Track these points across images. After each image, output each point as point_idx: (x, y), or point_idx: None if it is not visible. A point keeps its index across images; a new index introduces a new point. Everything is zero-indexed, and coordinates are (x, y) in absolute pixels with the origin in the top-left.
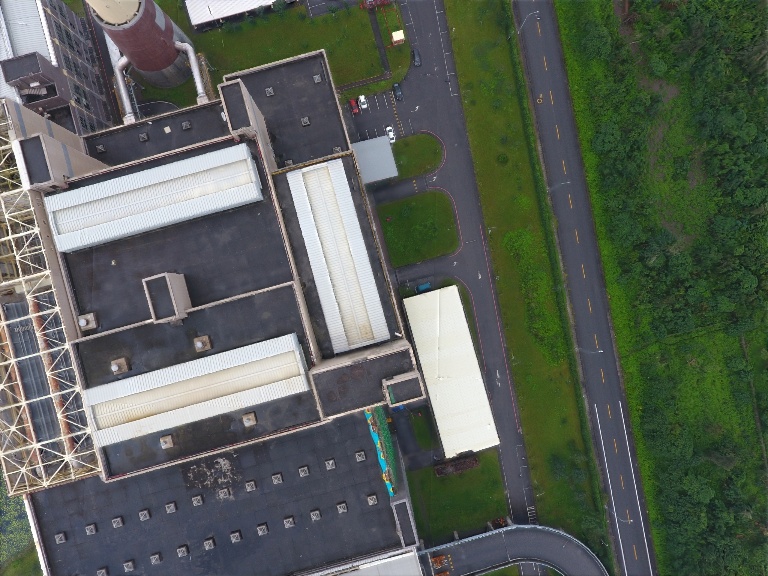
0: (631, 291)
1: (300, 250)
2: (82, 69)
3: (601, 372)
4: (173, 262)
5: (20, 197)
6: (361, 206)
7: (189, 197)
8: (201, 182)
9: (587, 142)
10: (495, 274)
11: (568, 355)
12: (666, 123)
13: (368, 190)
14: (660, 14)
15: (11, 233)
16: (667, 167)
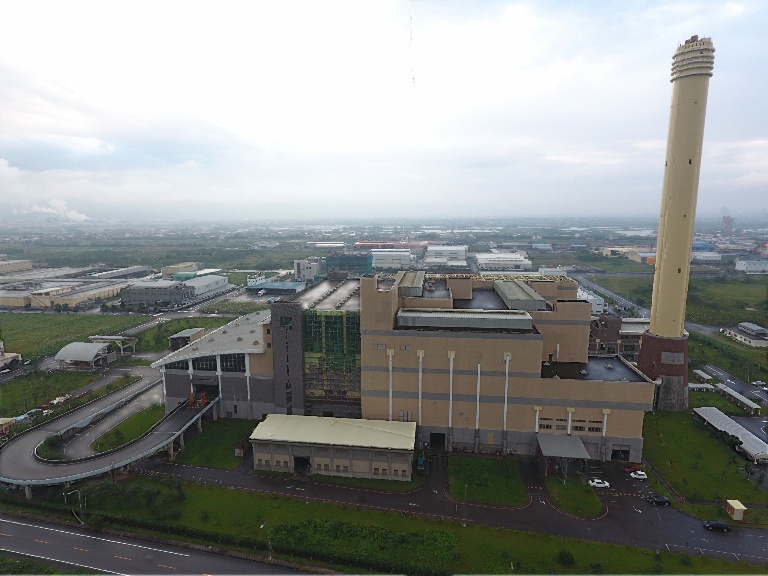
0: None
1: None
2: None
3: None
4: (480, 299)
5: None
6: None
7: None
8: None
9: None
10: None
11: None
12: None
13: (534, 459)
14: None
15: None
16: None
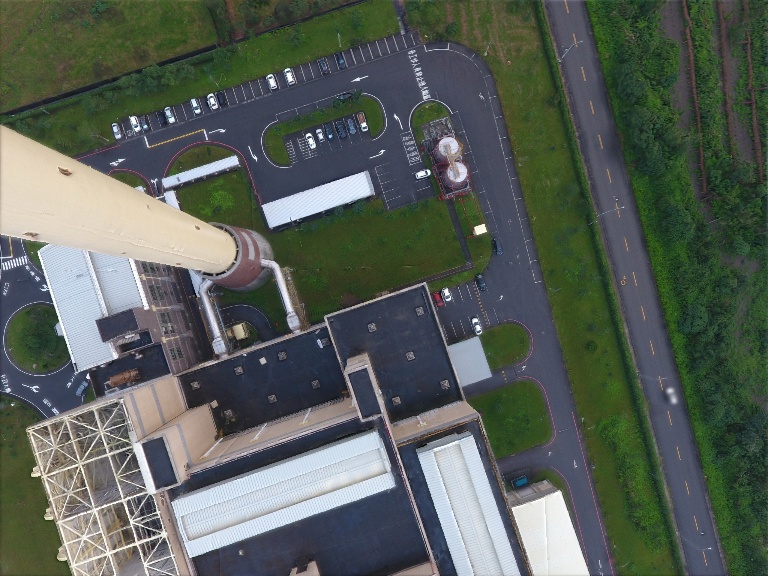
0: (728, 471)
1: (430, 521)
2: (163, 287)
3: (703, 555)
4: (303, 548)
5: (144, 500)
6: (490, 471)
7: (321, 490)
8: (333, 473)
9: (674, 323)
10: (591, 463)
11: (670, 541)
12: (749, 297)
13: None
14: (737, 191)
15: (137, 539)
16: (753, 340)
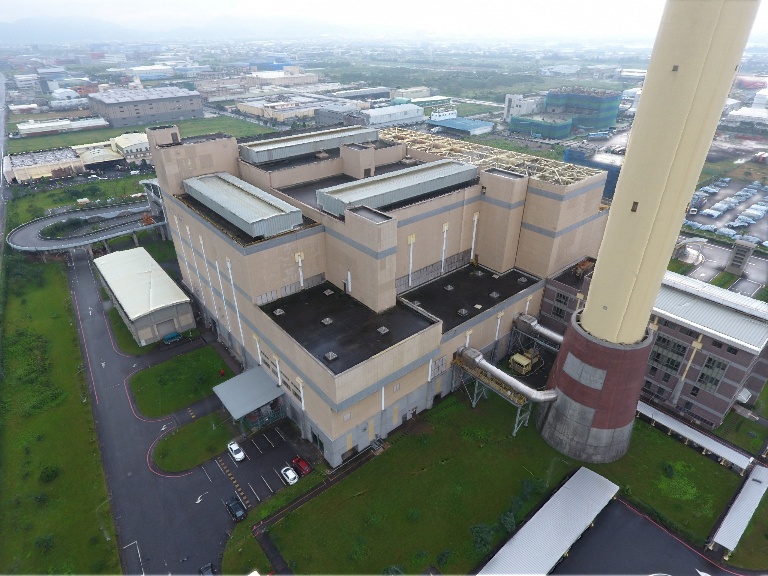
0: None
1: None
2: None
3: None
4: None
5: None
6: None
7: None
8: None
9: None
10: None
11: (4, 337)
12: None
13: None
14: None
15: None
16: None
